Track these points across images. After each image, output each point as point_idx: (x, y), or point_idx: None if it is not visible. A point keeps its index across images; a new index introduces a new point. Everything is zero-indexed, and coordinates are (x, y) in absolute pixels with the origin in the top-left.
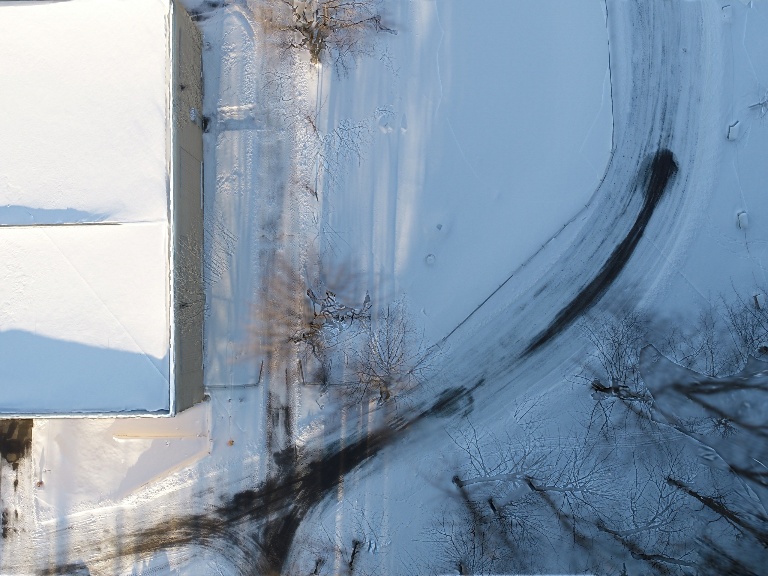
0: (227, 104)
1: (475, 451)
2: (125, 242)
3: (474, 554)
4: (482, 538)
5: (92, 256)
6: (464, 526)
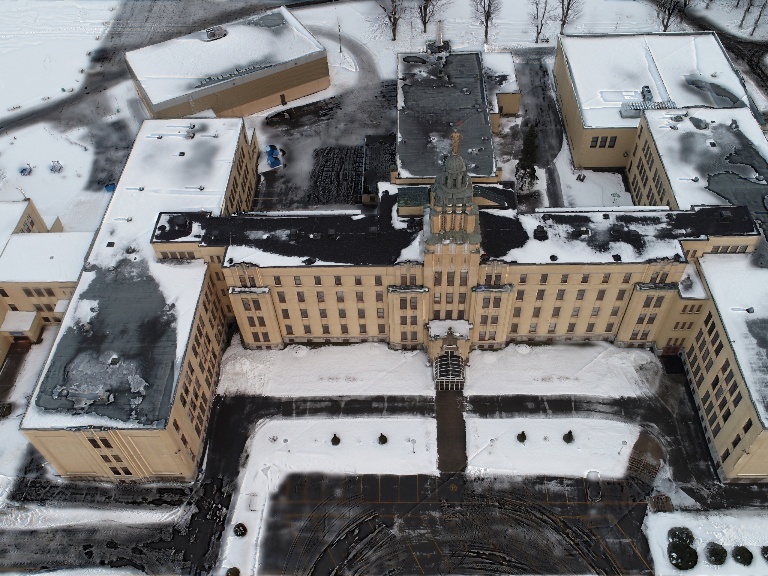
0: None
1: (695, 4)
2: None
3: (731, 3)
4: (725, 2)
5: None
6: (722, 6)
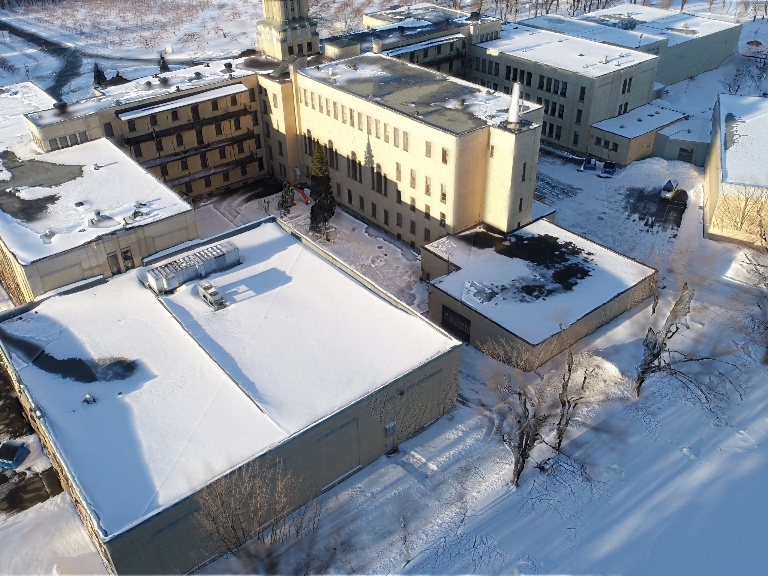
0: (421, 453)
1: None
2: (252, 423)
3: None
4: None
5: (225, 413)
6: None
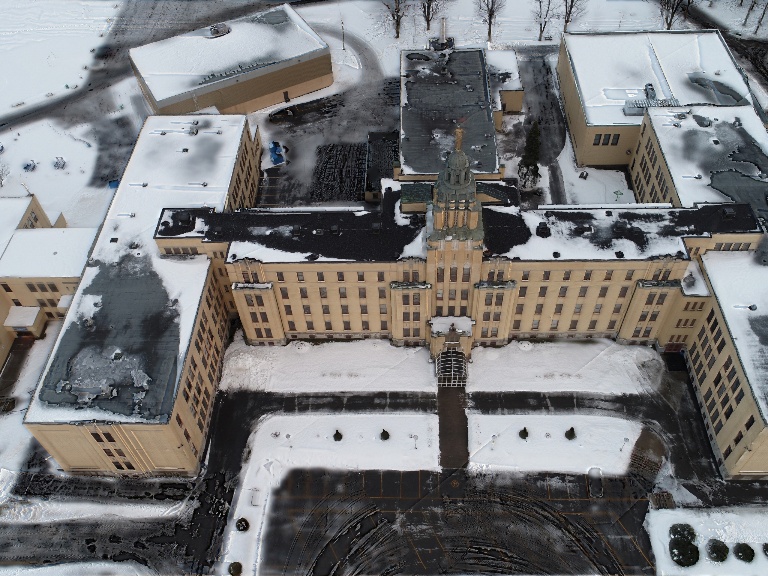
0: None
1: (699, 2)
2: None
3: (735, 1)
4: (728, 0)
5: None
6: None
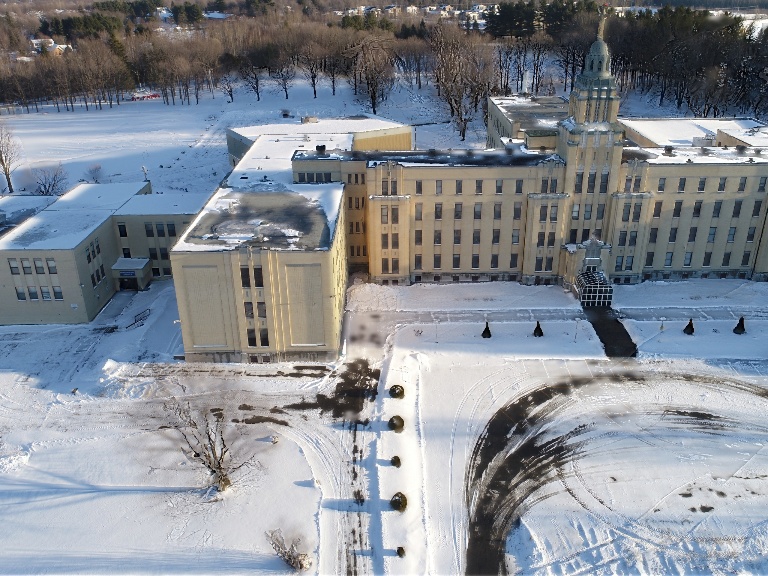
0: None
1: None
2: None
3: None
4: None
5: None
6: None
